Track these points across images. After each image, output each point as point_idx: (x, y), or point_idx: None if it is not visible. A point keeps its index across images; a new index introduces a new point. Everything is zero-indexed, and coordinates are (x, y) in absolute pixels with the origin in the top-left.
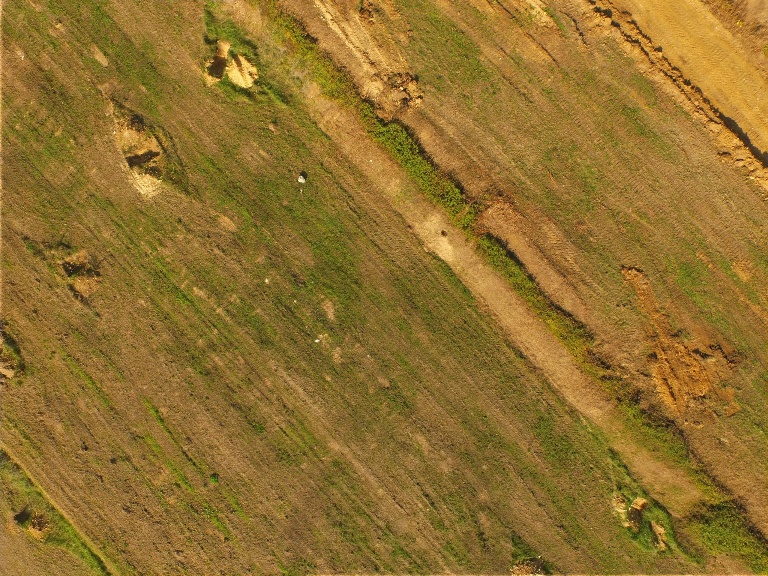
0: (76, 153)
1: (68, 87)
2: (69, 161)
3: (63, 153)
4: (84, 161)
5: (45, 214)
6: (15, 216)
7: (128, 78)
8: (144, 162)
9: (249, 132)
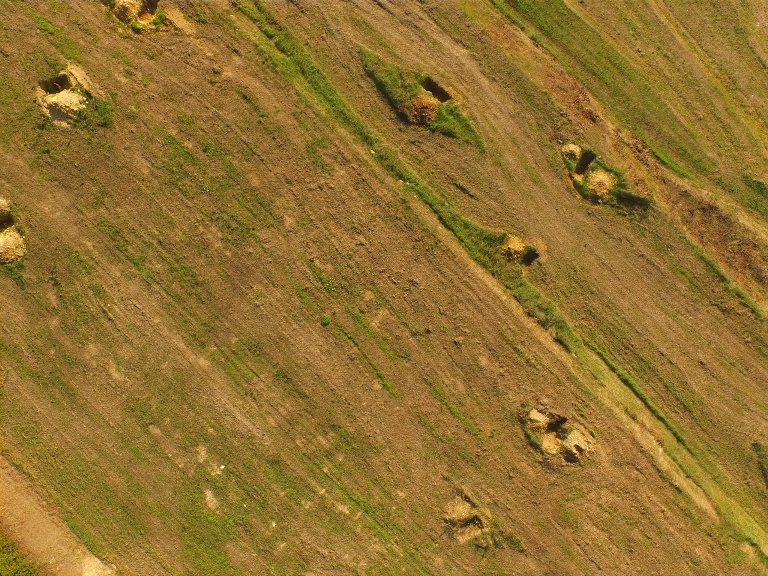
0: None
1: None
2: None
3: None
4: None
5: None
6: (533, 573)
7: None
8: None
9: None
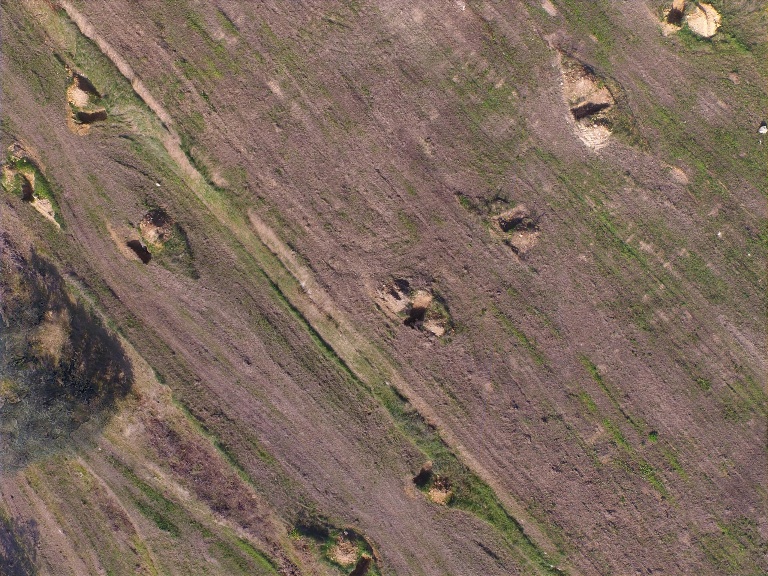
0: (518, 105)
1: (511, 38)
2: (510, 113)
3: (503, 105)
4: (526, 113)
5: (481, 168)
6: (448, 170)
7: (578, 28)
8: (592, 114)
9: (707, 82)
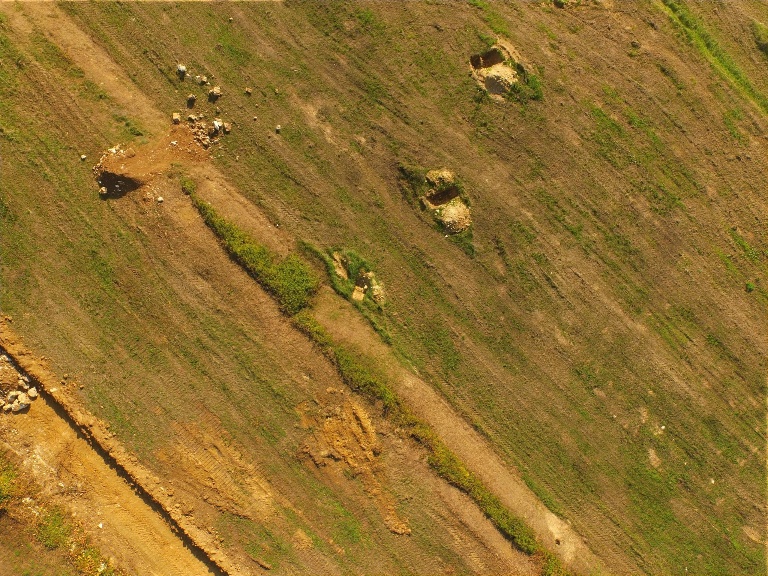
0: None
1: None
2: None
3: None
4: None
5: None
6: None
7: None
8: None
9: None
